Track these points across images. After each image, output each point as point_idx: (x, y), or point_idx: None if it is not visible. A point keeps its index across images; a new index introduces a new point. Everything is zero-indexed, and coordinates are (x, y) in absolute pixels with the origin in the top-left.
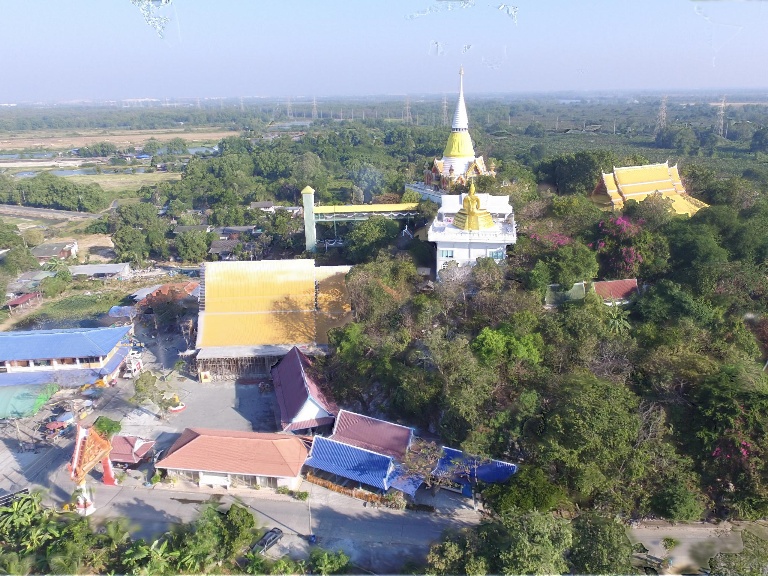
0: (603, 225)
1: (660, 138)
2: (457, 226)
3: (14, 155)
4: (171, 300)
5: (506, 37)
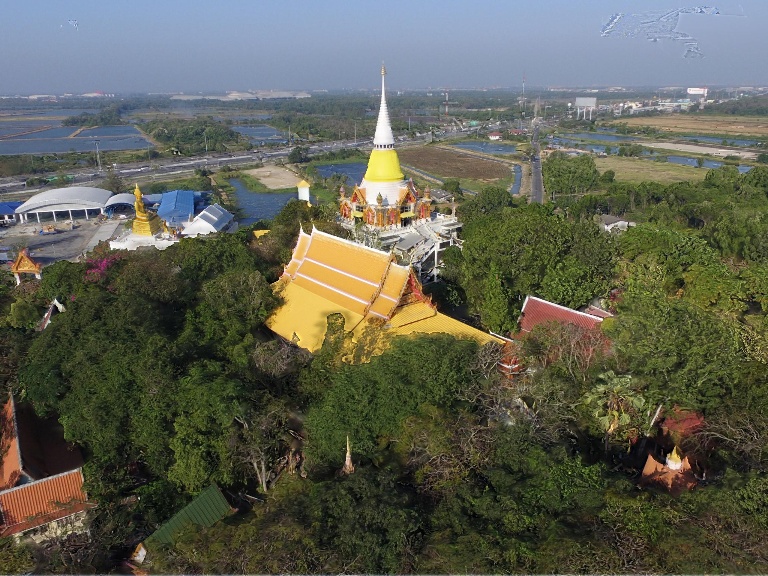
0: None
1: None
2: None
3: (721, 140)
4: None
5: (485, 14)
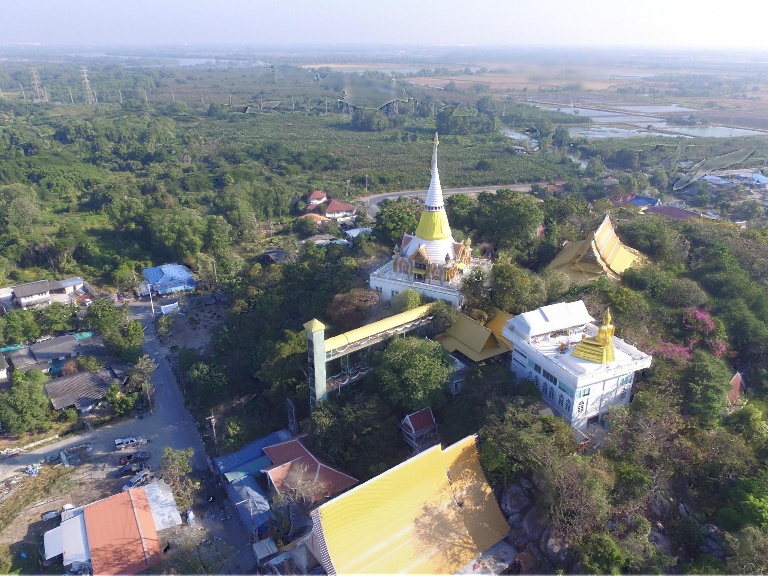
0: (687, 321)
1: (357, 120)
2: (587, 359)
3: None
4: (201, 561)
5: None
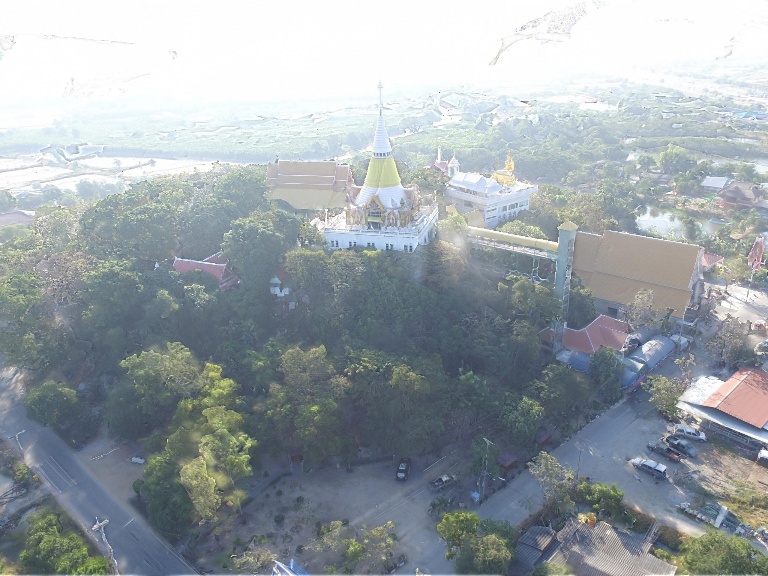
0: None
1: None
2: None
3: None
4: None
5: None
